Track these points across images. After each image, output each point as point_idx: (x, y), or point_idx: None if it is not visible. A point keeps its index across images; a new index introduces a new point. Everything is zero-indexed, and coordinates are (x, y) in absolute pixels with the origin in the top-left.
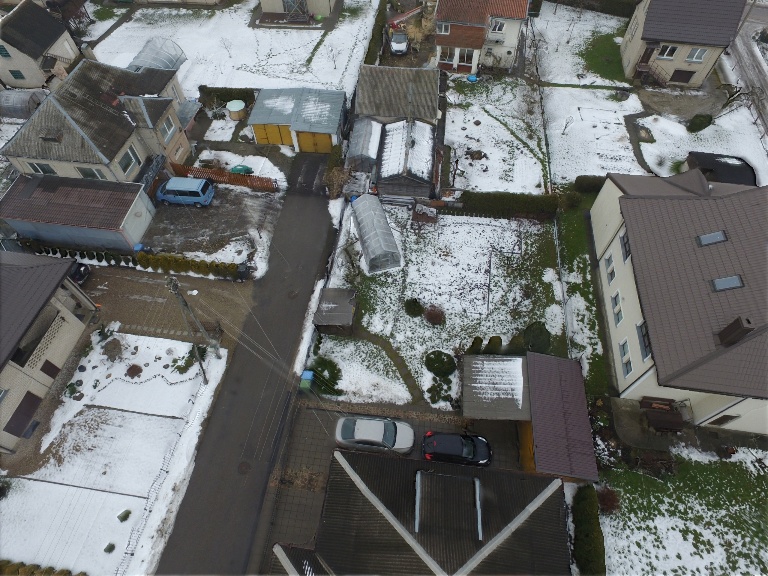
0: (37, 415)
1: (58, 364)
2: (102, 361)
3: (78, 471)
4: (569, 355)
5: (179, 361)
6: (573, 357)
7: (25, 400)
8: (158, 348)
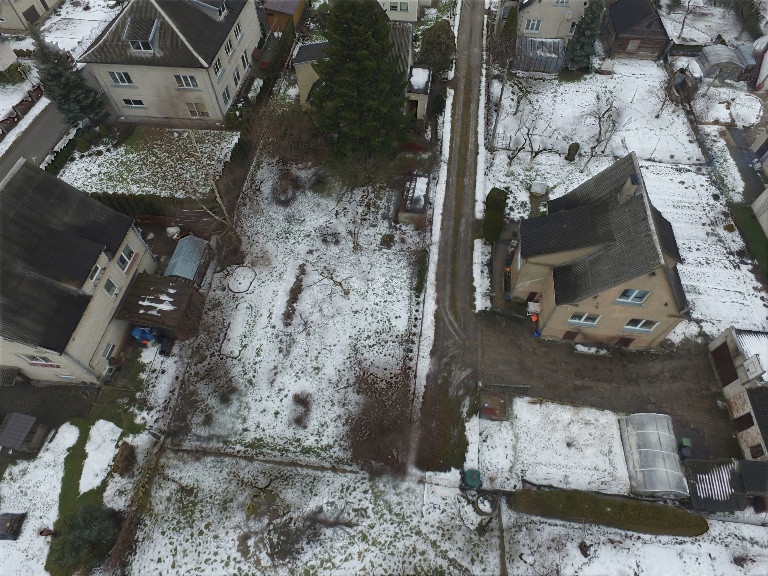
0: (38, 22)
1: (48, 5)
2: (71, 6)
3: (59, 34)
4: (311, 3)
5: (110, 5)
6: (313, 4)
7: (32, 8)
8: (100, 2)
